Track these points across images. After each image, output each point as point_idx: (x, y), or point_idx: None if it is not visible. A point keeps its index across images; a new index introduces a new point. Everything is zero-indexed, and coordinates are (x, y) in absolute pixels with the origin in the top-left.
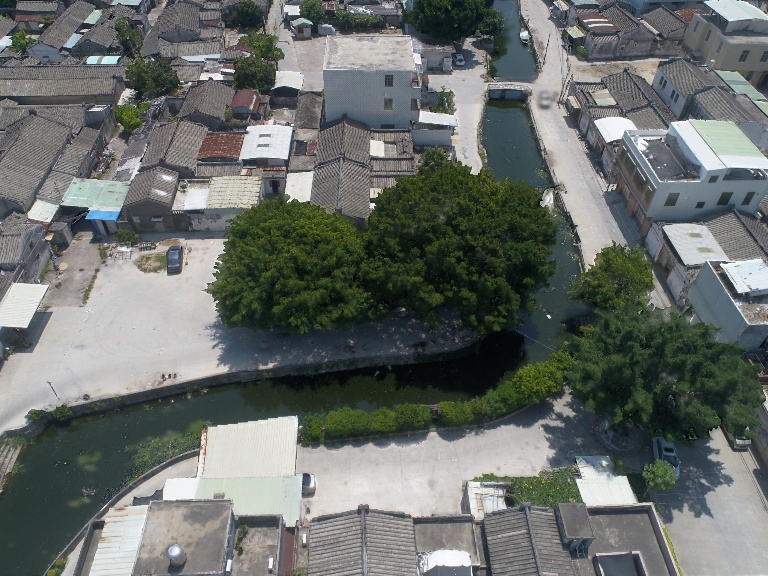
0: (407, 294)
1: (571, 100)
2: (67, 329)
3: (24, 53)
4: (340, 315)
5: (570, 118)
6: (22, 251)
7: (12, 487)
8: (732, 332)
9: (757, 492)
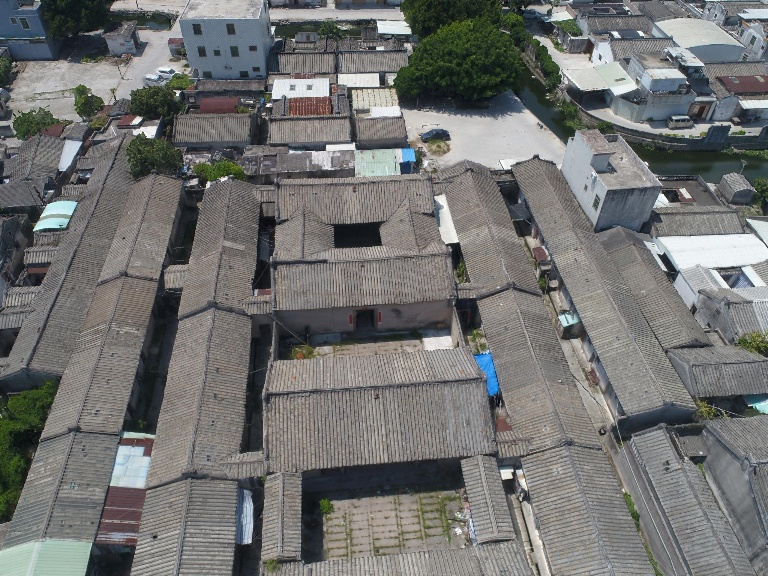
0: None
1: None
2: None
3: None
4: None
5: None
6: None
7: None
8: None
9: (535, 6)
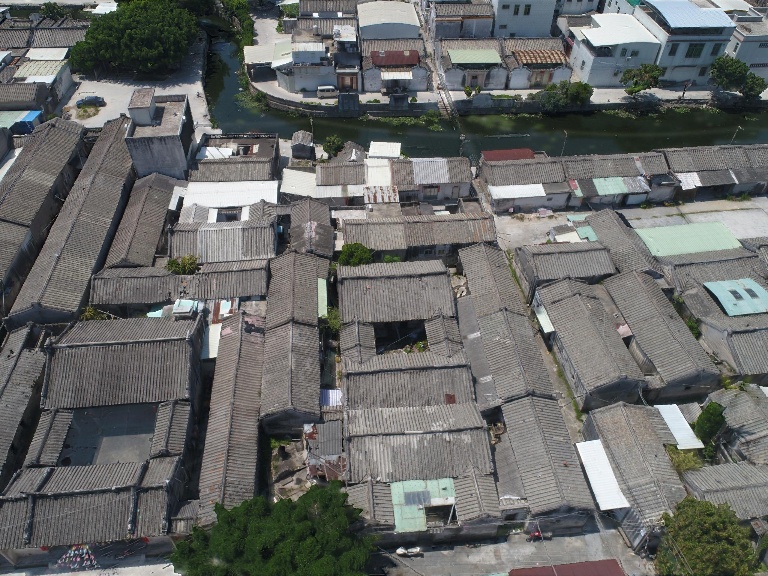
0: (188, 5)
1: None
2: None
3: None
4: None
5: None
6: None
7: None
8: None
9: None
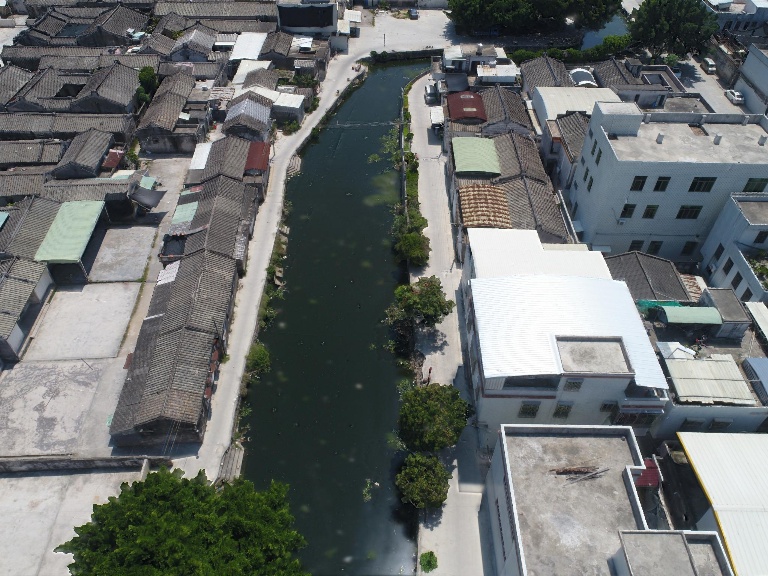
0: (549, 7)
1: None
2: (371, 33)
3: None
4: (517, 14)
5: None
6: None
7: (371, 76)
8: None
9: (717, 84)
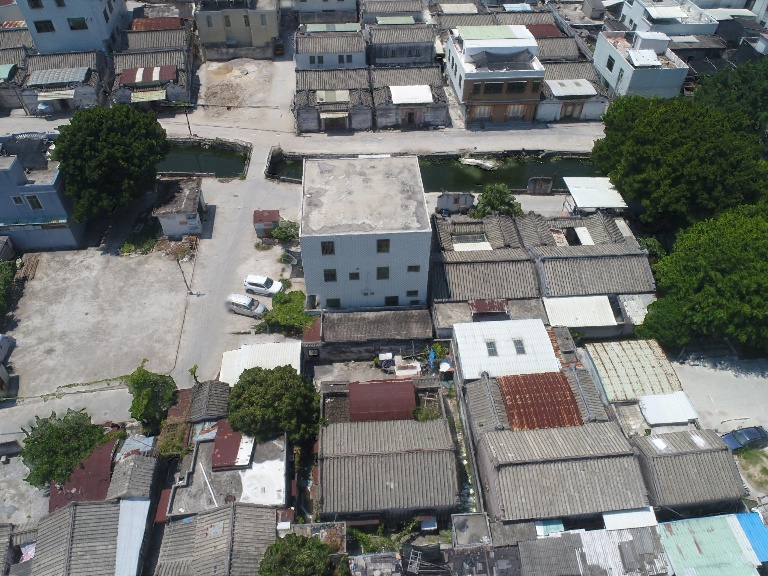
0: None
1: (329, 116)
2: None
3: None
4: None
5: (332, 133)
6: None
7: None
8: (676, 82)
9: None
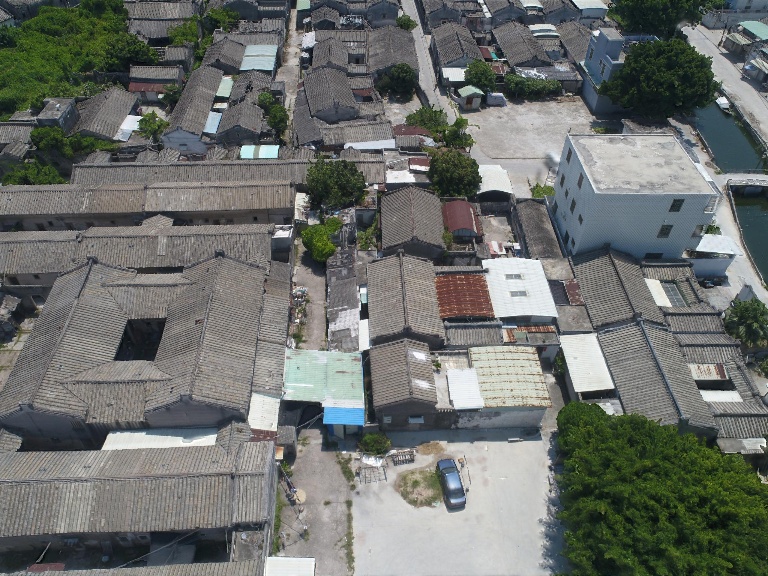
0: None
1: None
2: None
3: (155, 139)
4: None
5: None
6: (268, 501)
7: None
8: None
9: None
